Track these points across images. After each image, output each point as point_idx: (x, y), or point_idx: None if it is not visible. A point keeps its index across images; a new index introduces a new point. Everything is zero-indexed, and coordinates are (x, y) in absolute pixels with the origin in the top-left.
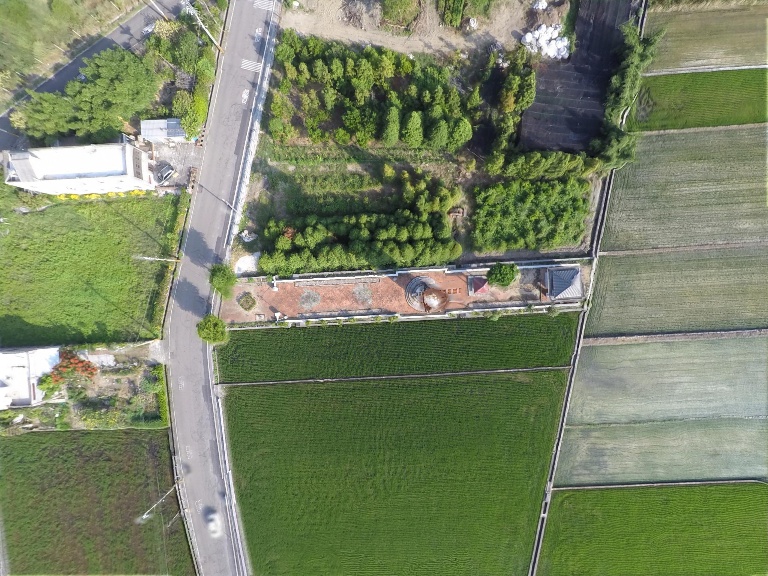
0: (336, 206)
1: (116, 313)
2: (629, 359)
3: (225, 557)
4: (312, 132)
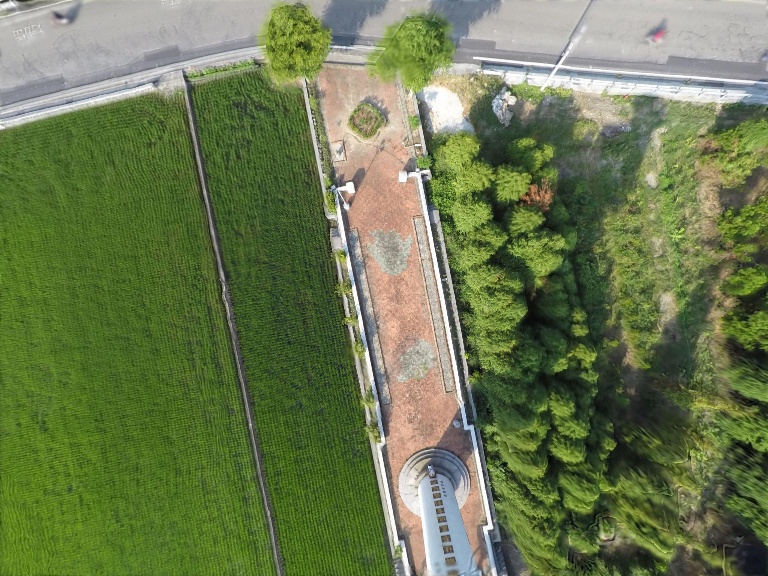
0: (590, 282)
1: None
2: None
3: None
4: (746, 215)
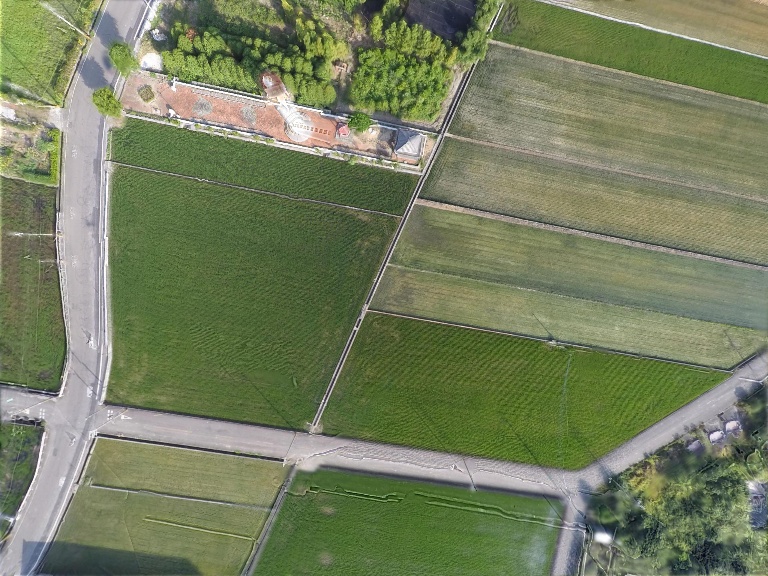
0: (241, 30)
1: (22, 72)
2: (447, 222)
3: (91, 308)
4: None
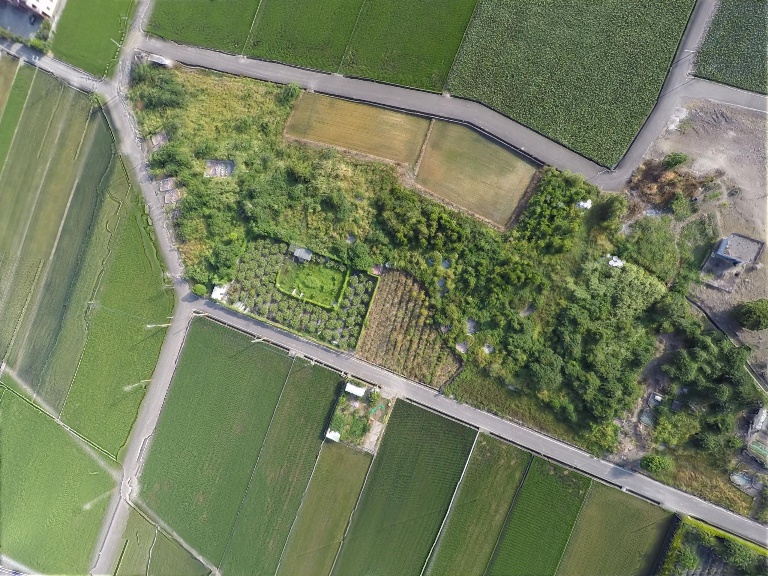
0: None
1: None
2: None
3: None
4: None
